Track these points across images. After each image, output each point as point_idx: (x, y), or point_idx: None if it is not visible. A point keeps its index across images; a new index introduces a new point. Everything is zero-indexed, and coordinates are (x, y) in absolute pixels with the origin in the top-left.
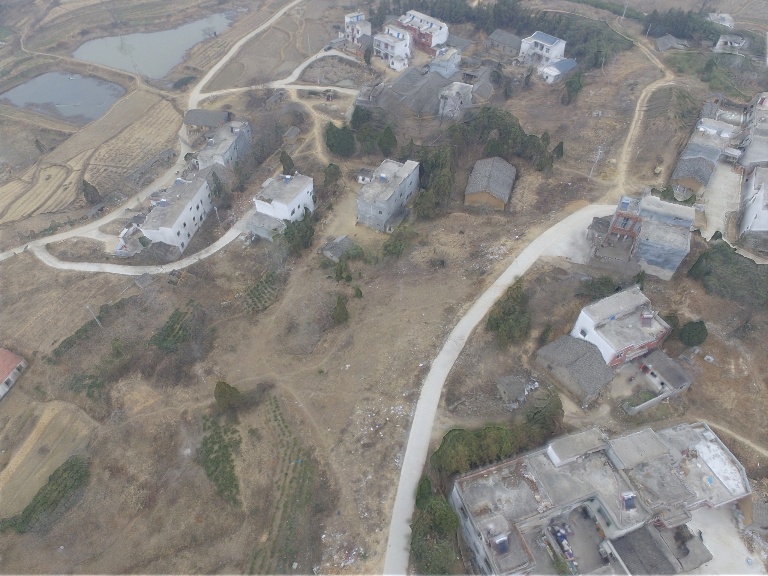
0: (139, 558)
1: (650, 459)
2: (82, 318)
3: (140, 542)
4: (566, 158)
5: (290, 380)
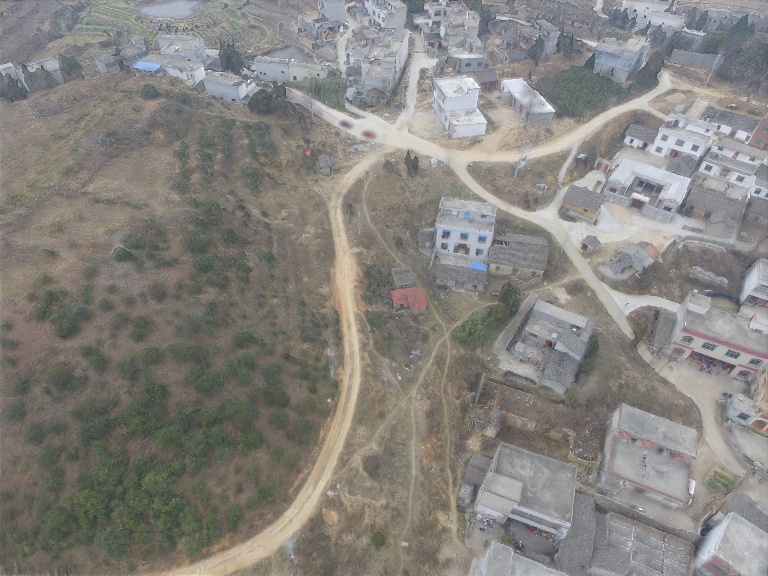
0: None
1: None
2: None
3: None
4: (755, 98)
5: None
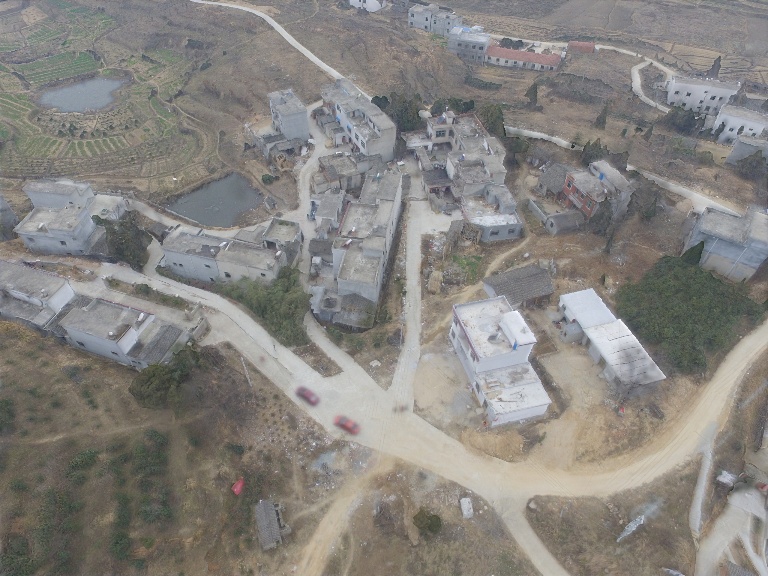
0: (452, 95)
1: (486, 165)
2: (590, 78)
3: (459, 96)
4: None
5: (547, 117)
